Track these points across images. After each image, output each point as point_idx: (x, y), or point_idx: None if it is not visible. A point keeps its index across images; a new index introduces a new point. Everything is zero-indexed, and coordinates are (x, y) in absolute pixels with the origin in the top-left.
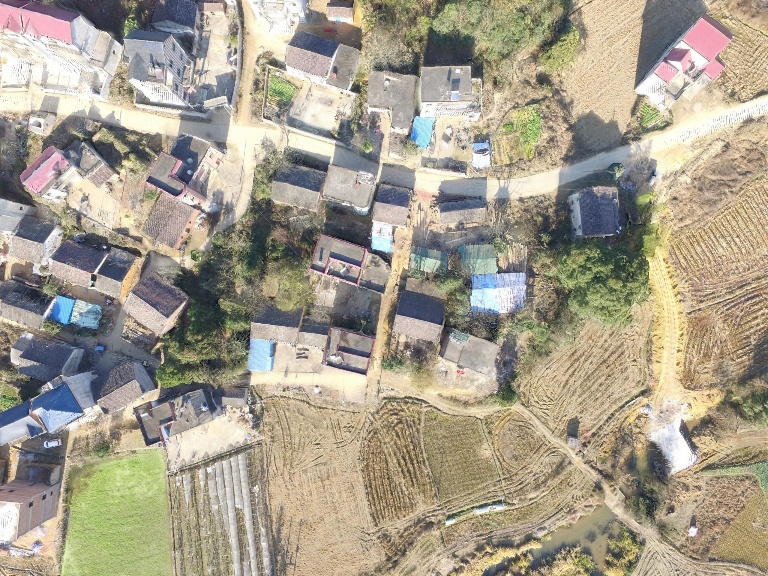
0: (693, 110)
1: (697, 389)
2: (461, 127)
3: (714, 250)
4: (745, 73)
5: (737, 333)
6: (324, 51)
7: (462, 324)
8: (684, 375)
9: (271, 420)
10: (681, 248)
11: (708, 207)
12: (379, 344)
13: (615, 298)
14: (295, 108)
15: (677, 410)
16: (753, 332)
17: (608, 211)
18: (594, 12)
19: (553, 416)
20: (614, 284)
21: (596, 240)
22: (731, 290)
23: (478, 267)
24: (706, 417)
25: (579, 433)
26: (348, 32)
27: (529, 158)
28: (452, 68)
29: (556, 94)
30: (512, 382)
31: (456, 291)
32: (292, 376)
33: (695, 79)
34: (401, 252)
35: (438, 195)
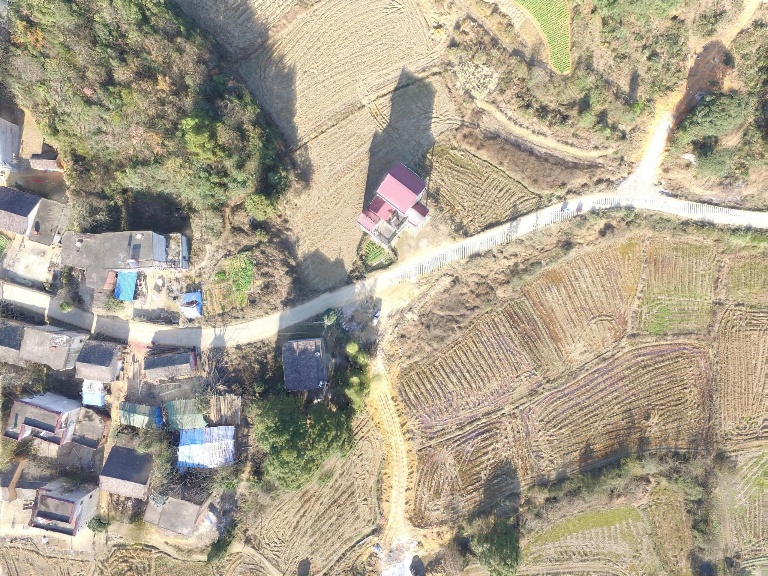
0: (419, 246)
1: (427, 527)
2: (173, 277)
3: (444, 386)
4: (473, 206)
5: (467, 469)
6: (21, 209)
7: (158, 487)
8: (414, 513)
9: (1, 571)
10: (411, 385)
11: (436, 344)
12: (105, 493)
13: (287, 471)
14: (8, 259)
15: (406, 549)
16: (484, 467)
17: (309, 365)
18: (321, 147)
19: (284, 558)
20: (286, 456)
21: (306, 390)
22: (461, 426)
23: (186, 422)
24: (441, 552)
25: (310, 574)
26: (59, 181)
27: (242, 306)
28: (133, 233)
29: (279, 234)
30: (232, 531)
31: (153, 454)
32: (19, 527)
33: (399, 227)
34: (118, 403)
35: (152, 346)
